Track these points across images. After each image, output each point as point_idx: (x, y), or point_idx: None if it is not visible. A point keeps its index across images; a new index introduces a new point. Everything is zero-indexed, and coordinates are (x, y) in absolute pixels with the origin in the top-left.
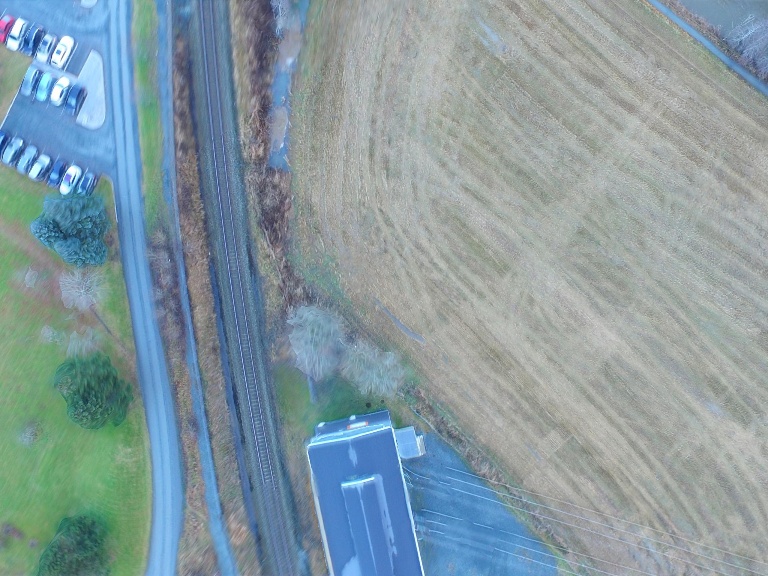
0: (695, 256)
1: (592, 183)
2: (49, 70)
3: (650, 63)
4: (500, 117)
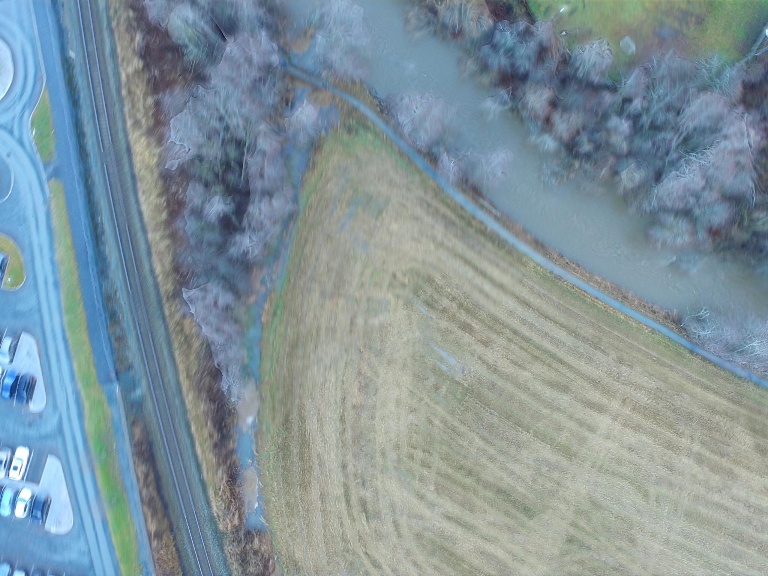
0: (688, 544)
1: (573, 490)
2: (9, 484)
3: (612, 360)
4: (470, 439)
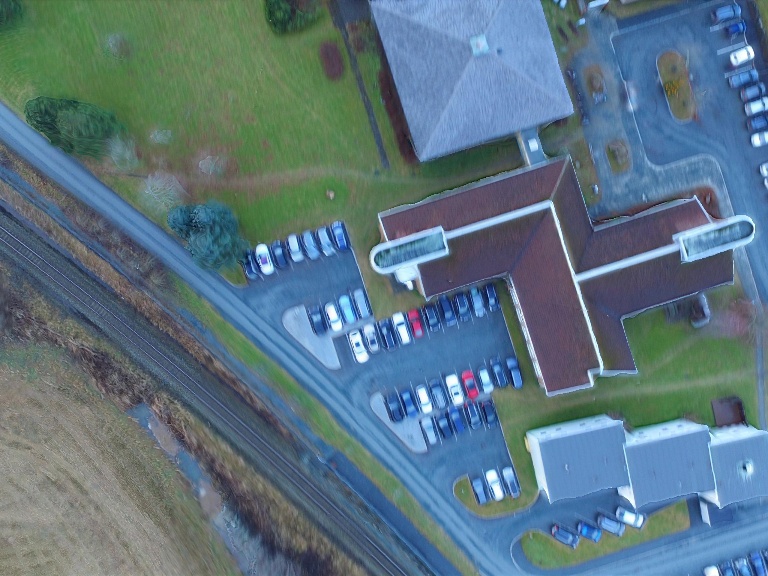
0: None
1: None
2: (357, 324)
3: None
4: None
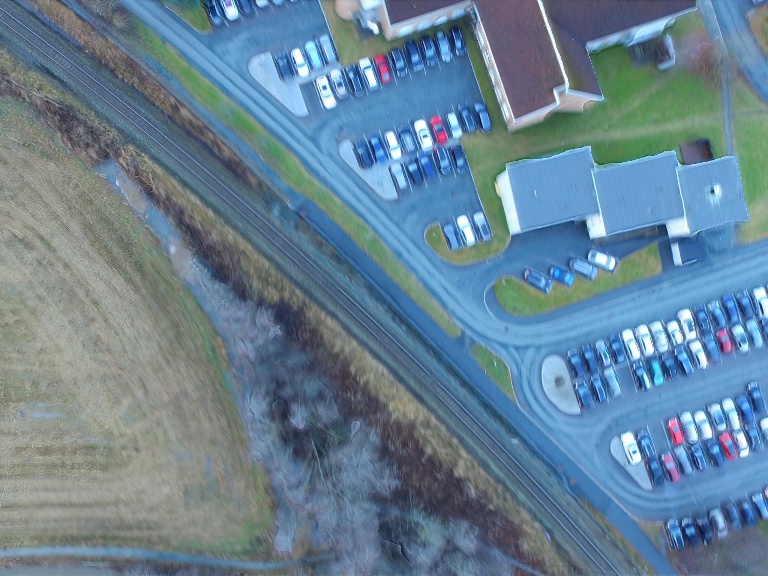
0: None
1: None
2: (324, 70)
3: None
4: None
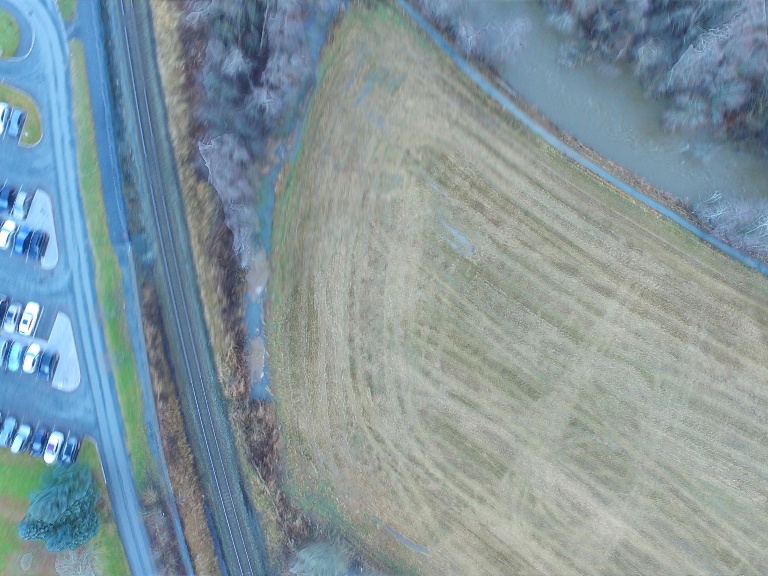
0: (691, 432)
1: (578, 373)
2: (18, 339)
3: (622, 245)
4: (478, 318)
